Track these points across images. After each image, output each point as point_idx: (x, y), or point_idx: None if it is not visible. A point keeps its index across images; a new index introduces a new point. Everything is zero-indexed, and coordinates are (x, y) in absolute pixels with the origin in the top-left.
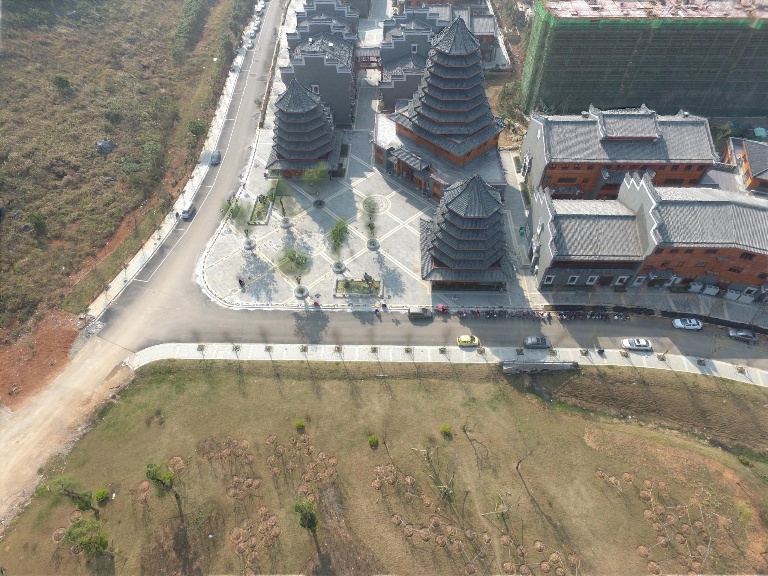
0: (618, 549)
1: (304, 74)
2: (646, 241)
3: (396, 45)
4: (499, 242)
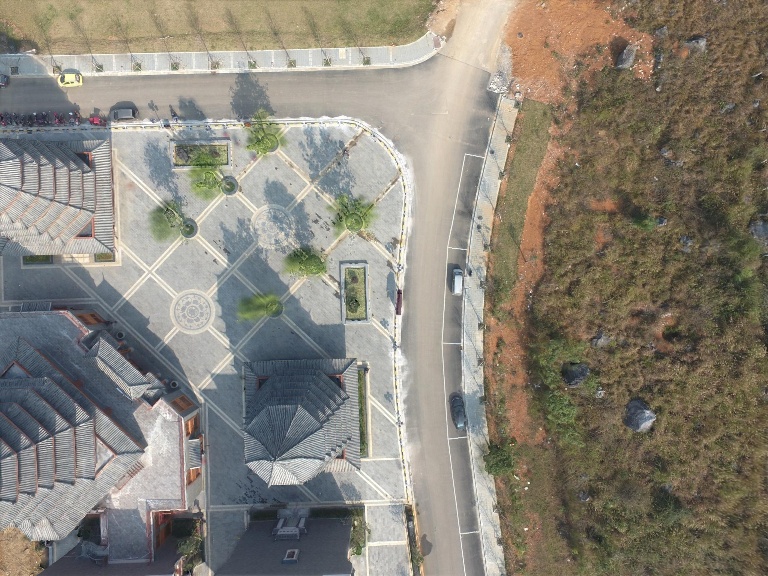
0: None
1: (305, 575)
2: None
3: None
4: None
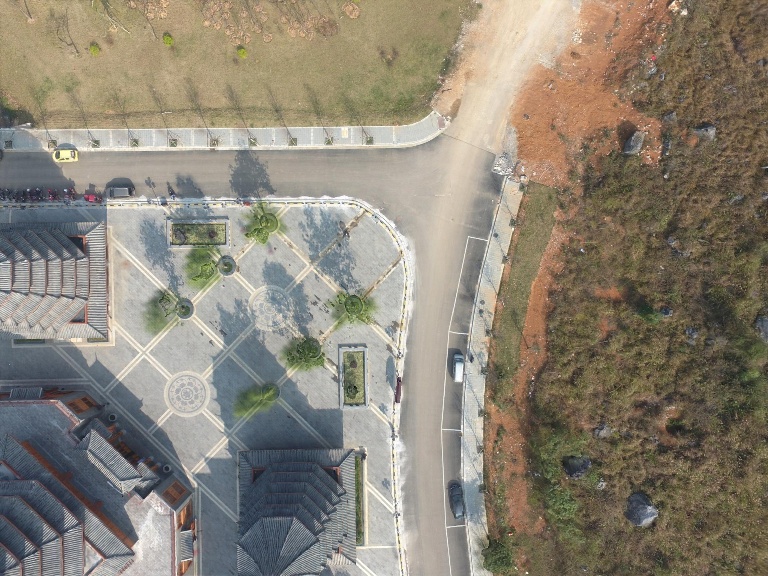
0: None
1: None
2: None
3: None
4: None
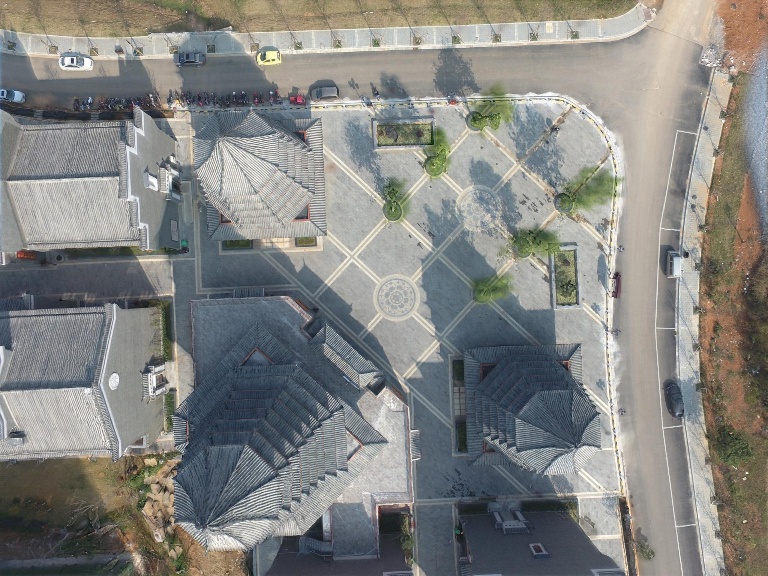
0: None
1: (570, 570)
2: (7, 133)
3: None
4: None
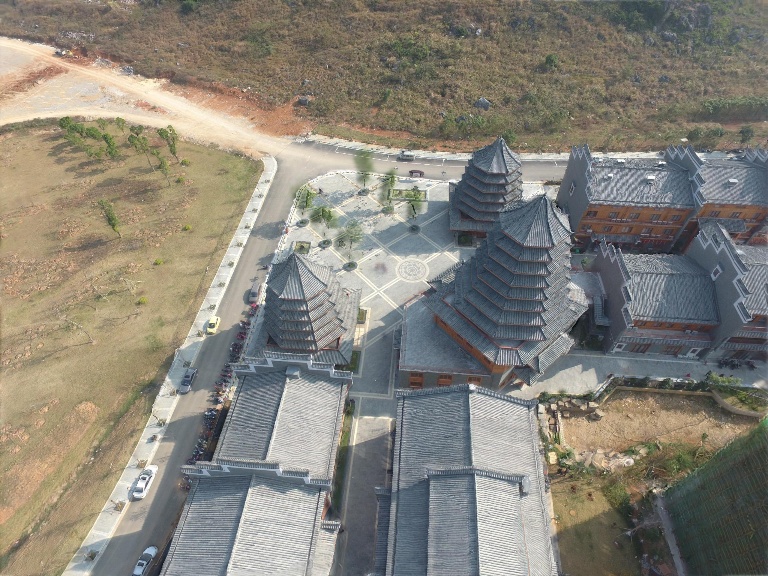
0: (4, 396)
1: None
2: None
3: (710, 249)
4: (281, 330)
